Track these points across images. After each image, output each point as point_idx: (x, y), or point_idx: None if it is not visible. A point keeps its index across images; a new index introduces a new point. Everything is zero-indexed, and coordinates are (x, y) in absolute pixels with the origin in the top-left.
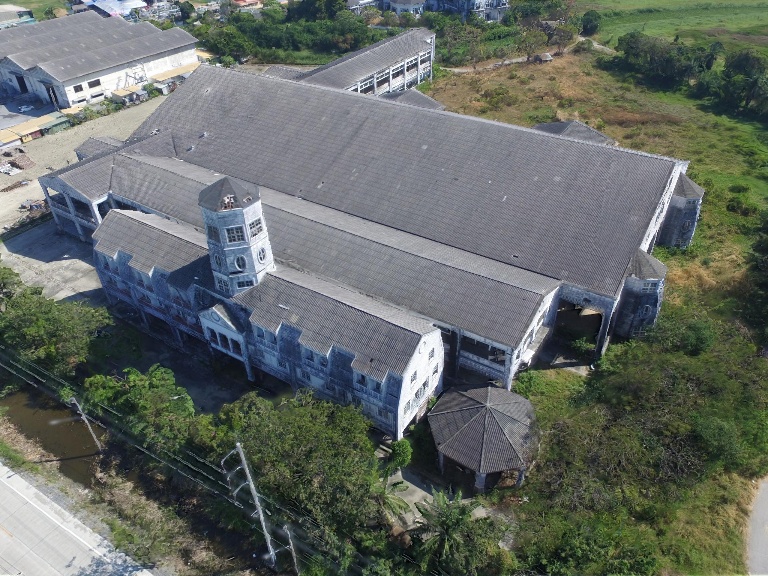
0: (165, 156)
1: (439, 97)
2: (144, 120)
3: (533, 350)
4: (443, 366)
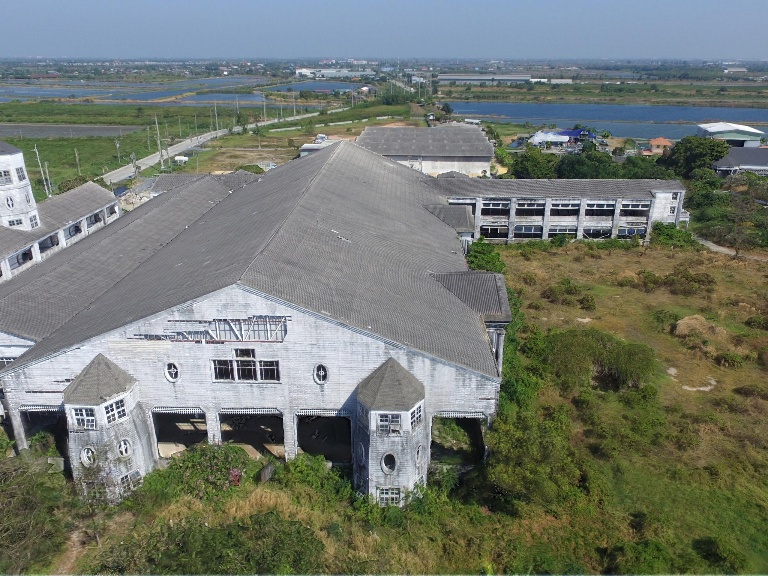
0: (230, 187)
1: (615, 257)
2: None
3: None
4: None
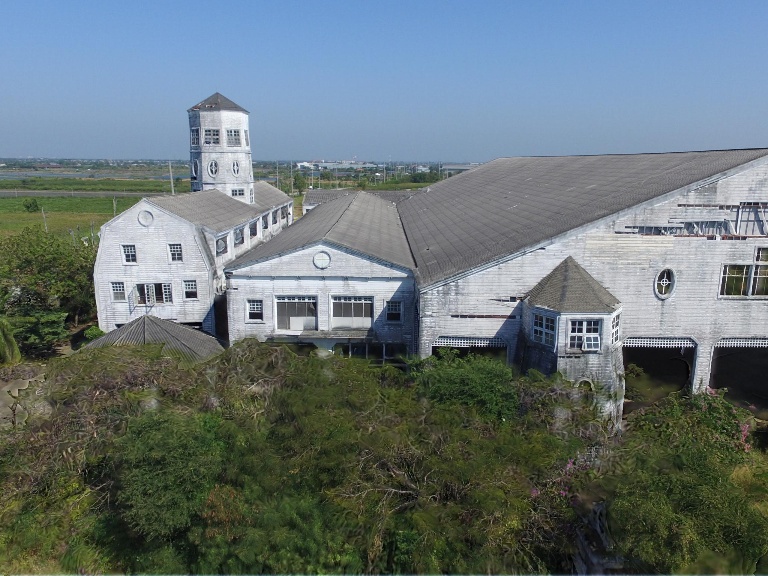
0: (390, 200)
1: None
2: None
3: (303, 333)
4: (214, 300)
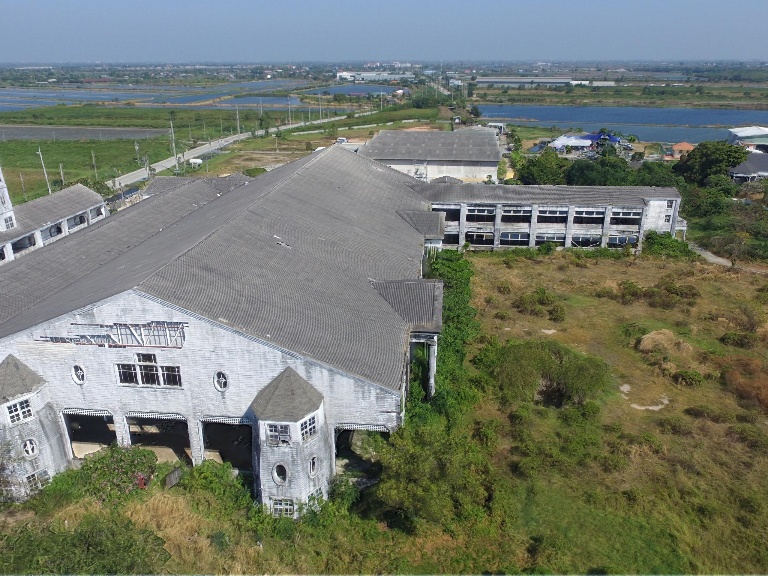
0: (220, 190)
1: (601, 267)
2: None
3: None
4: None
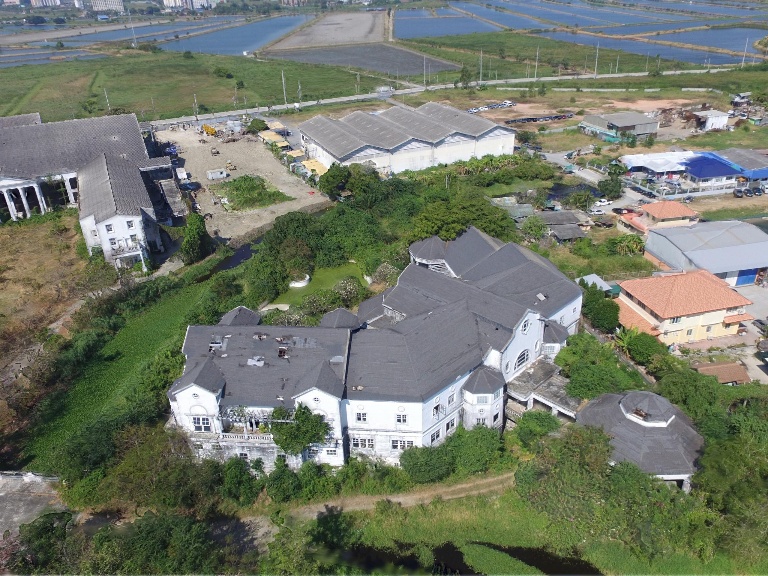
0: None
1: (56, 256)
2: (245, 163)
3: None
4: None
